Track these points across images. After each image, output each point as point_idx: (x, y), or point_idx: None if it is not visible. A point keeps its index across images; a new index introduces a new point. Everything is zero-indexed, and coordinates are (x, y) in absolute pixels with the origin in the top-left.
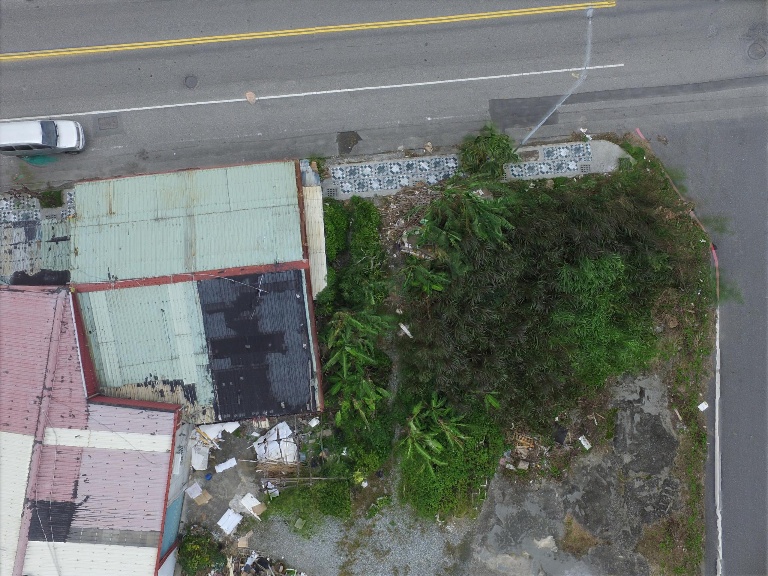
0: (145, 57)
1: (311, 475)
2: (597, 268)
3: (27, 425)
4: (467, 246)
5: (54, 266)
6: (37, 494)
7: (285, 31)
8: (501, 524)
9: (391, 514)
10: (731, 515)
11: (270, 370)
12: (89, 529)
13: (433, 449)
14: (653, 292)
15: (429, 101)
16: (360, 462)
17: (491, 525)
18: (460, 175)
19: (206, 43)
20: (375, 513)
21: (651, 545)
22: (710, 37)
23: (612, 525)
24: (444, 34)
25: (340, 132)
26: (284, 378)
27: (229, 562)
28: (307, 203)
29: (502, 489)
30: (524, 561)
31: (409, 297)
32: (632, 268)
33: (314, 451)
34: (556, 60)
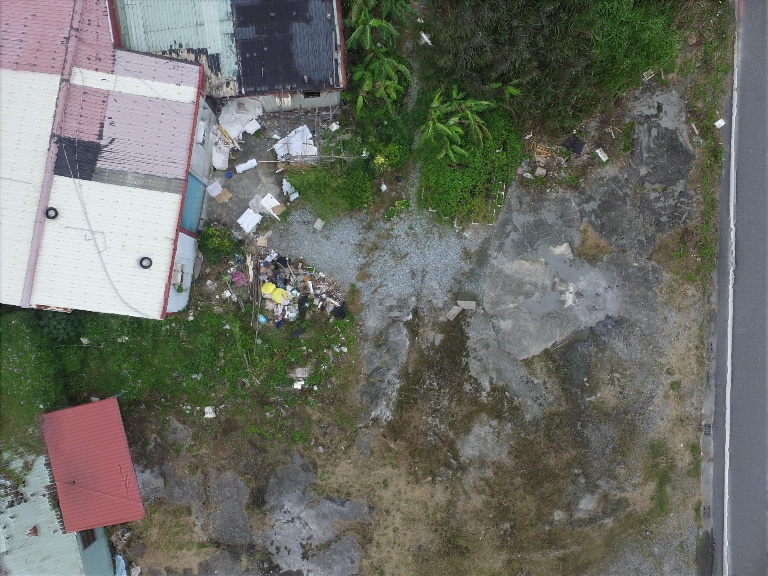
0: None
1: None
2: None
3: (54, 65)
4: None
5: None
6: (63, 131)
7: None
8: (518, 231)
9: (409, 219)
10: (745, 228)
11: (294, 40)
12: (114, 171)
13: (453, 136)
14: None
15: None
16: None
17: (508, 232)
18: None
19: None
20: (393, 215)
21: (665, 254)
22: None
23: (627, 234)
24: None
25: None
26: (308, 50)
27: (248, 259)
28: None
29: (519, 197)
30: (540, 267)
31: (431, 3)
32: None
33: None
34: None
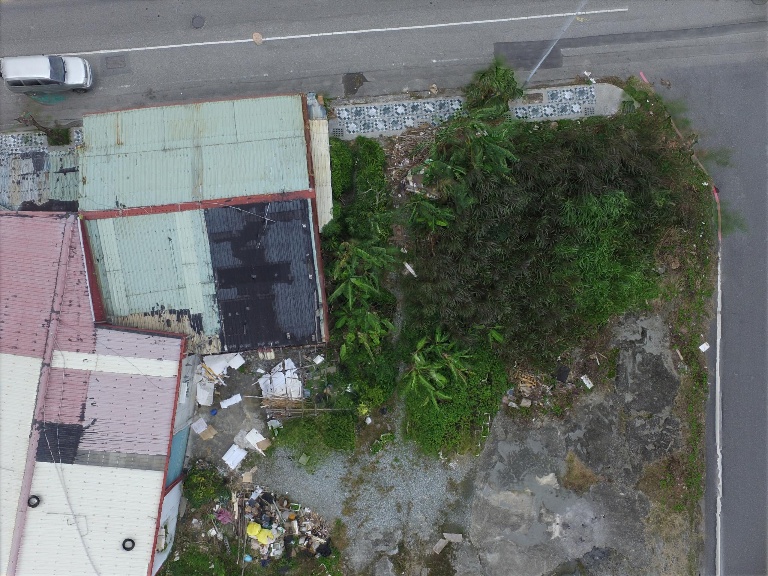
0: None
1: (316, 406)
2: (601, 202)
3: (35, 348)
4: (472, 179)
5: (62, 196)
6: (45, 416)
7: None
8: (503, 461)
9: (394, 451)
10: (731, 454)
11: (276, 300)
12: (96, 452)
13: (437, 382)
14: (656, 230)
15: (434, 43)
16: (364, 397)
17: (494, 462)
18: (465, 116)
19: None
20: (379, 449)
21: (652, 483)
22: None
23: (613, 463)
24: None
25: (346, 73)
26: (290, 309)
27: (234, 497)
28: (313, 136)
29: (505, 427)
30: (526, 498)
31: (414, 236)
32: (635, 205)
33: (318, 388)
34: (561, 4)
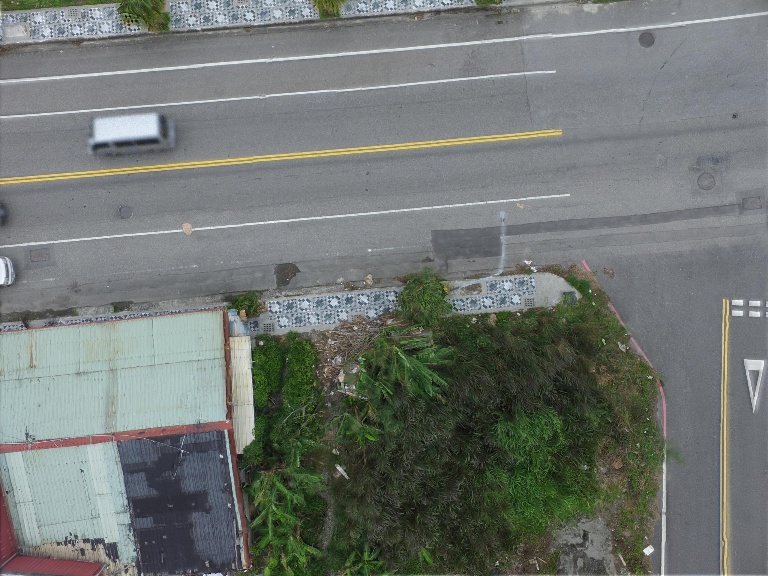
0: (79, 187)
1: None
2: (532, 424)
3: None
4: (398, 402)
5: None
6: None
7: (222, 160)
8: None
9: None
10: None
11: (194, 529)
12: None
13: None
14: None
15: (370, 232)
16: None
17: None
18: (400, 310)
19: (141, 173)
20: None
21: None
22: (659, 166)
23: None
24: (386, 163)
25: (278, 264)
26: (208, 537)
27: None
28: (234, 355)
29: None
30: None
31: (345, 438)
32: (571, 418)
33: None
34: (500, 190)
